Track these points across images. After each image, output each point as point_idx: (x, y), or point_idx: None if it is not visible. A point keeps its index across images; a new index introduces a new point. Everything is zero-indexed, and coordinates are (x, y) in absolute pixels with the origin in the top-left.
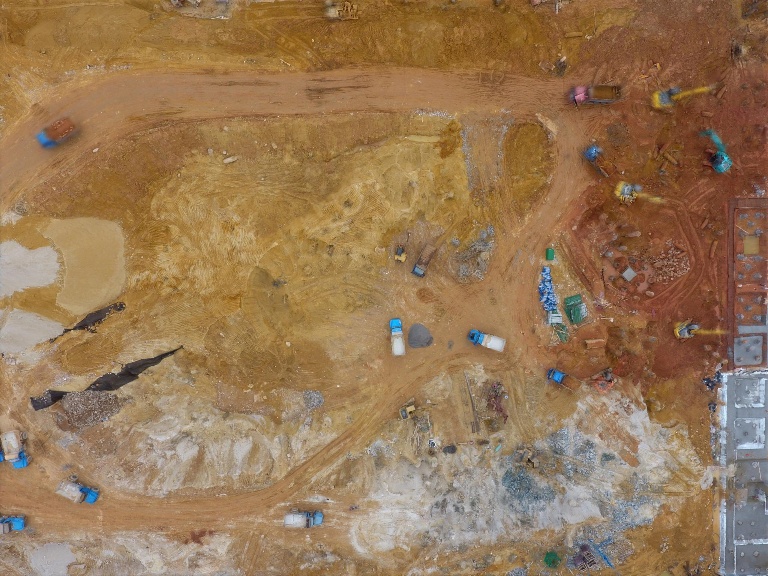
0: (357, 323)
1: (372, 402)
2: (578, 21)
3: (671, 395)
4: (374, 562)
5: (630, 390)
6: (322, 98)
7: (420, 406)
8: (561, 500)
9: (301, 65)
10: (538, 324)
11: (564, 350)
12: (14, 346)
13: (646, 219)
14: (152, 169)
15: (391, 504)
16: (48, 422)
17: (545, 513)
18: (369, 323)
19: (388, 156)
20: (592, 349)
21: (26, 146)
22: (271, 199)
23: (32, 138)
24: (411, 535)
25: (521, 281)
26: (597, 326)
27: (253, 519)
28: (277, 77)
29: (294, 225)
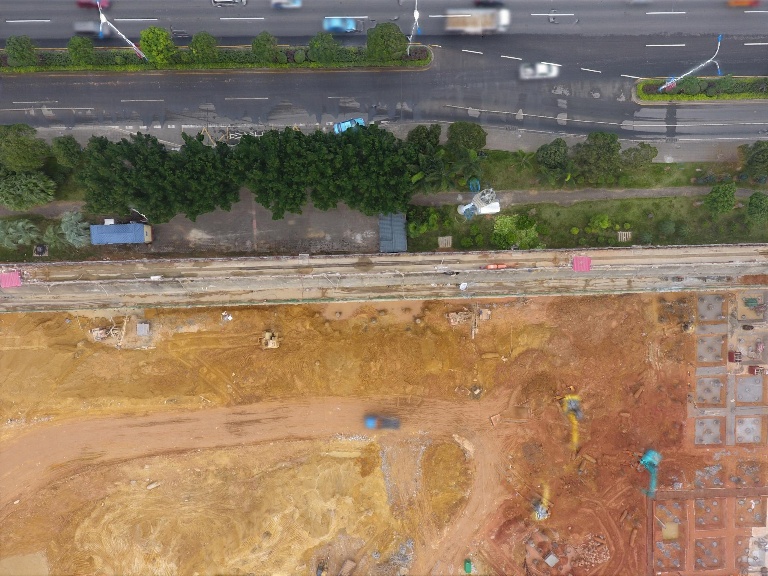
0: None
1: None
2: (495, 340)
3: None
4: None
5: None
6: (242, 430)
7: None
8: None
9: (221, 400)
10: None
11: None
12: None
13: (565, 517)
14: (75, 504)
15: None
16: None
17: None
18: None
19: (308, 479)
20: None
21: None
22: (195, 518)
23: None
24: None
25: None
26: None
27: None
28: (198, 414)
29: (216, 547)
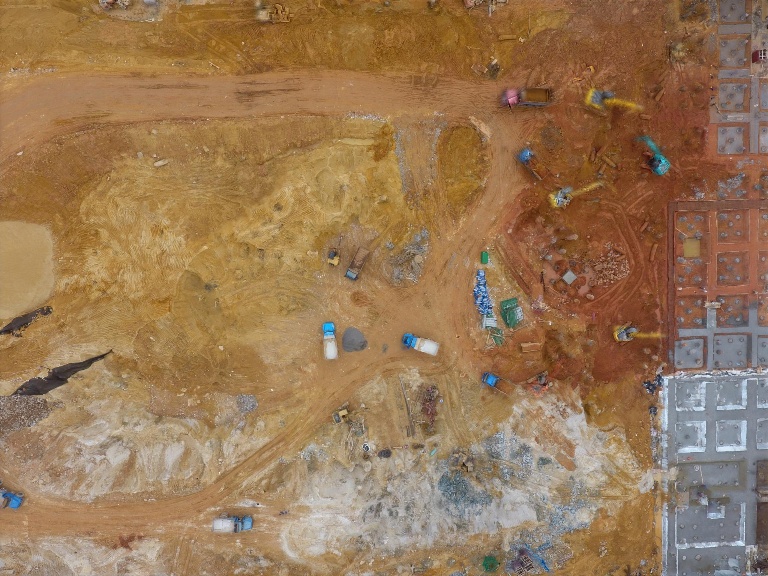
0: (291, 327)
1: (306, 406)
2: (512, 24)
3: (611, 398)
4: (308, 567)
5: (566, 394)
6: (252, 101)
7: (354, 410)
8: (498, 504)
9: (231, 68)
10: (473, 328)
11: (499, 354)
12: None
13: (584, 222)
14: (80, 172)
15: (322, 509)
16: None
17: (481, 517)
18: (303, 327)
19: (320, 159)
20: (528, 353)
21: None
22: (203, 202)
23: None
24: (342, 540)
25: (456, 284)
26: (534, 329)
27: (183, 524)
28: (206, 80)
29: (226, 228)
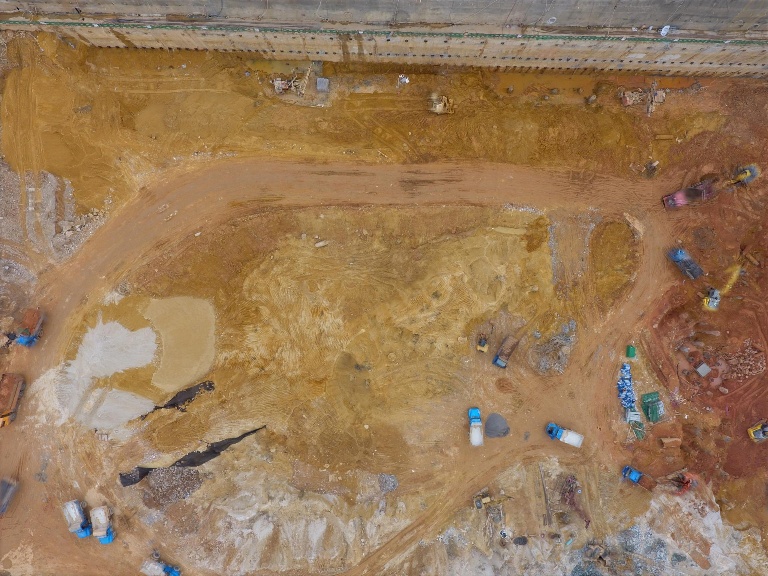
0: (435, 409)
1: (446, 489)
2: (669, 123)
3: (741, 494)
4: None
5: (704, 491)
6: (416, 190)
7: (493, 496)
8: None
9: (398, 157)
10: (615, 420)
11: (640, 447)
12: (108, 423)
13: (725, 318)
14: (247, 251)
15: None
16: (135, 499)
17: None
18: (447, 410)
19: (476, 248)
20: (668, 448)
21: (132, 228)
22: (358, 283)
23: (138, 220)
24: None
25: (600, 376)
26: (673, 424)
27: None
28: (374, 168)
29: (380, 311)
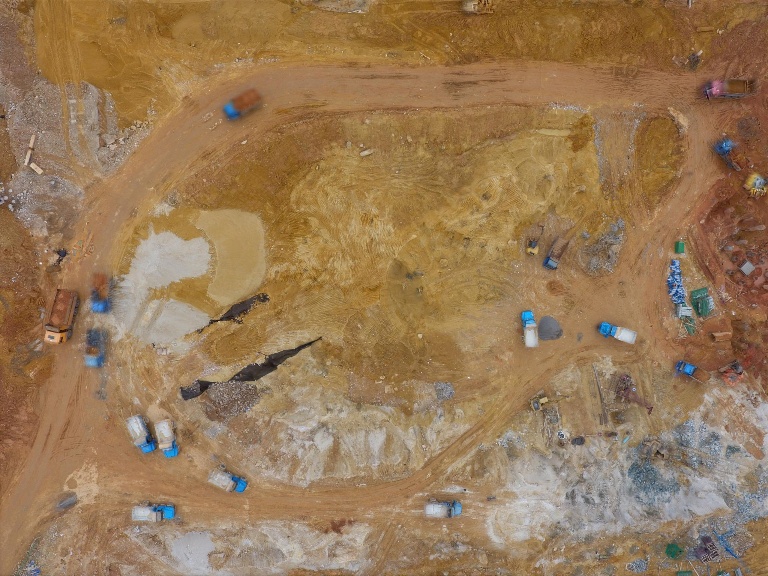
0: (488, 315)
1: (502, 394)
2: (708, 15)
3: None
4: (505, 552)
5: (756, 383)
6: (460, 91)
7: (549, 398)
8: (685, 492)
9: (440, 59)
10: (666, 317)
11: (692, 343)
12: (166, 336)
13: None
14: (293, 162)
15: (528, 495)
16: (197, 412)
17: (670, 505)
18: (499, 315)
19: (522, 149)
20: (719, 342)
21: (177, 138)
22: (405, 192)
23: (183, 130)
24: (546, 526)
25: (650, 274)
26: (722, 319)
27: (391, 509)
28: (417, 70)
29: (429, 218)
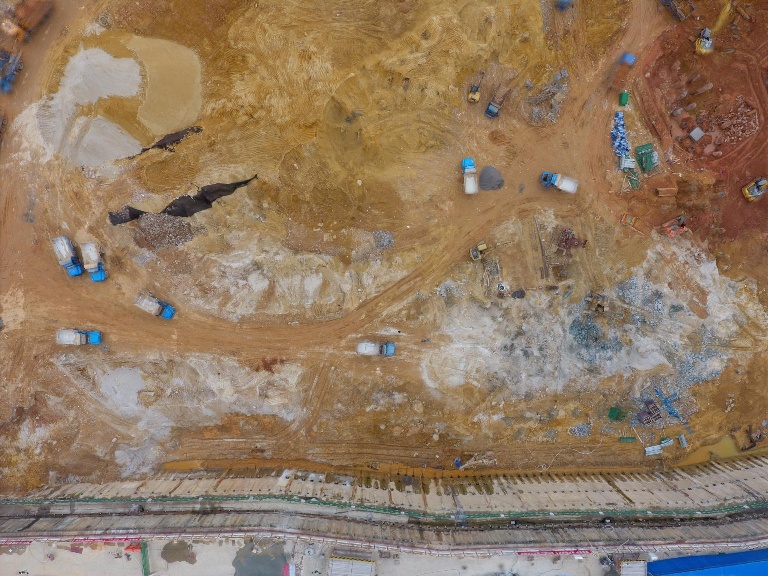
0: (428, 164)
1: (442, 244)
2: None
3: (737, 256)
4: (441, 403)
5: (700, 241)
6: None
7: None
8: (628, 352)
9: None
10: (609, 170)
11: (635, 197)
12: (94, 158)
13: (717, 73)
14: None
15: (463, 338)
16: (125, 238)
17: (612, 363)
18: (440, 164)
19: None
20: (663, 197)
21: None
22: (346, 36)
23: None
24: (481, 372)
25: (593, 126)
26: (667, 177)
27: (324, 350)
28: None
29: (369, 60)
